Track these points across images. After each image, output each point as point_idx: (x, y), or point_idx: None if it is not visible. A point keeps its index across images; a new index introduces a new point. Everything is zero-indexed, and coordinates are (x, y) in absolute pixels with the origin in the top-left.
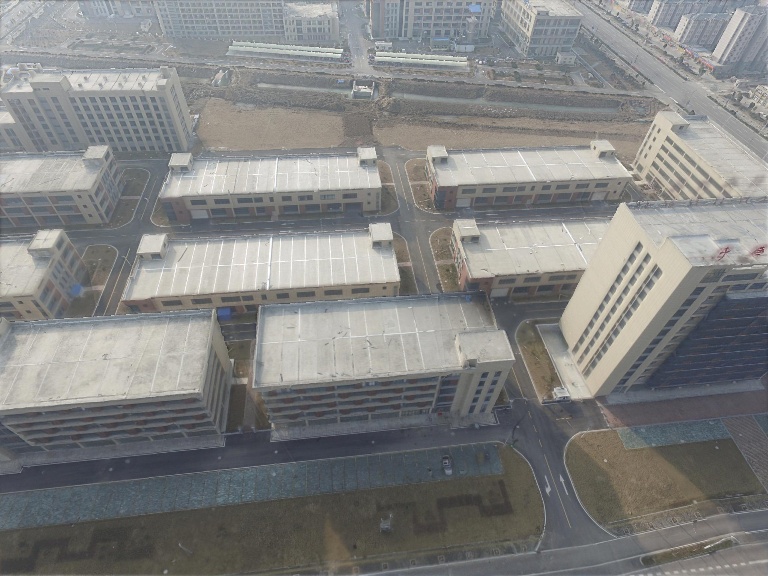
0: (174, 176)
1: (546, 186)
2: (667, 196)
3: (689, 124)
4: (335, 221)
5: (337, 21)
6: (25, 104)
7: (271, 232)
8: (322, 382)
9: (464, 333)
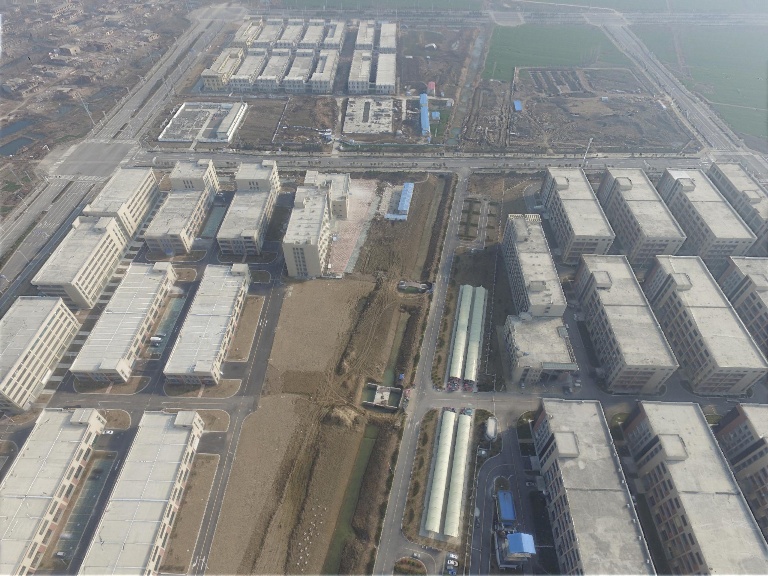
0: (230, 269)
1: None
2: None
3: None
4: None
5: None
6: None
7: (179, 322)
8: (4, 317)
9: None
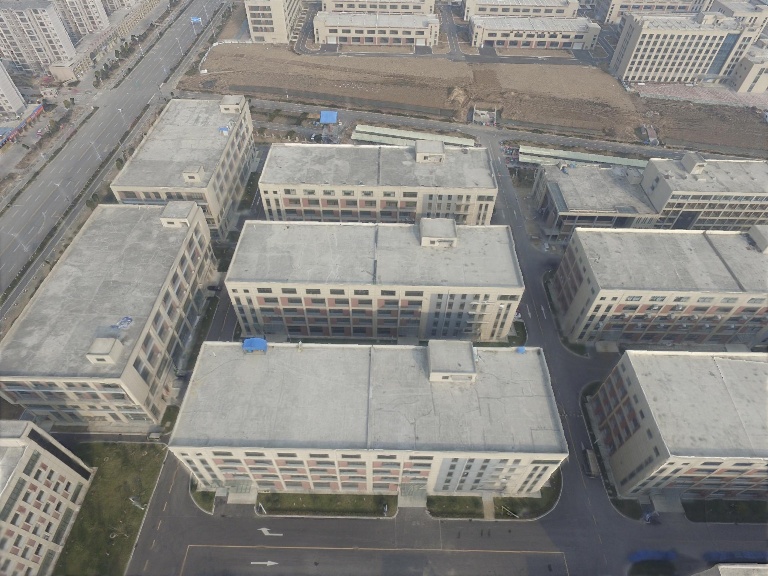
0: None
1: None
2: None
3: None
4: None
5: None
6: None
7: None
8: None
9: None
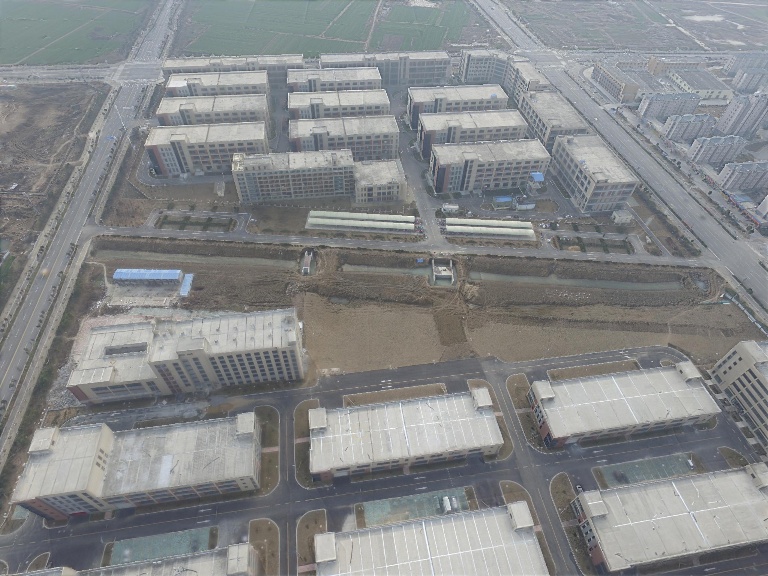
0: (315, 437)
1: (646, 425)
2: (750, 420)
3: None
4: (461, 471)
5: (406, 186)
6: (169, 366)
7: (408, 491)
8: None
9: None
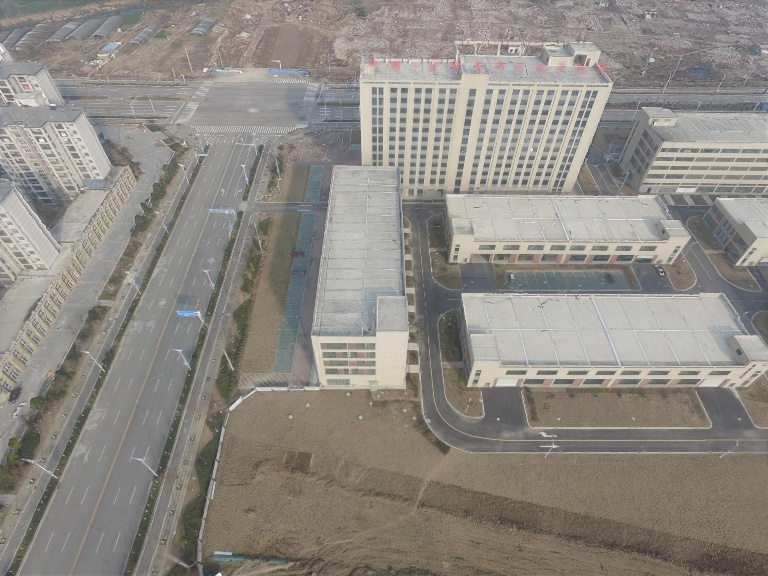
0: None
1: None
2: None
3: (379, 297)
4: None
5: None
6: None
7: None
8: None
9: (674, 117)
